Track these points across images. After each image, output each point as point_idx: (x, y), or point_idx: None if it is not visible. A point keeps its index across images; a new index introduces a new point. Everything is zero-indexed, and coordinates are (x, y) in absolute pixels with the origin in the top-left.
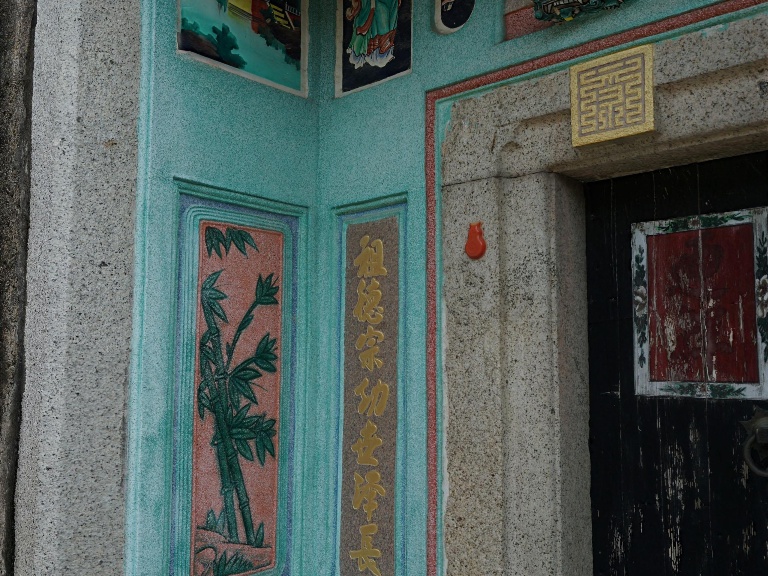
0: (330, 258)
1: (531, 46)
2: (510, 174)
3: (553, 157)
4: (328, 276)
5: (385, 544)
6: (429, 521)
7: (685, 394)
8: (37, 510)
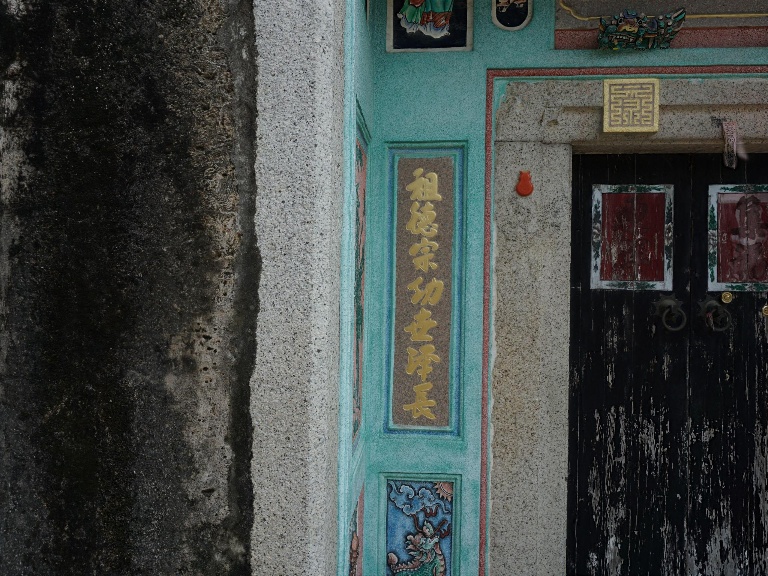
0: (383, 182)
1: (580, 58)
2: (545, 141)
3: (579, 135)
4: (382, 196)
5: (440, 396)
6: (484, 375)
7: (621, 288)
8: (312, 389)
